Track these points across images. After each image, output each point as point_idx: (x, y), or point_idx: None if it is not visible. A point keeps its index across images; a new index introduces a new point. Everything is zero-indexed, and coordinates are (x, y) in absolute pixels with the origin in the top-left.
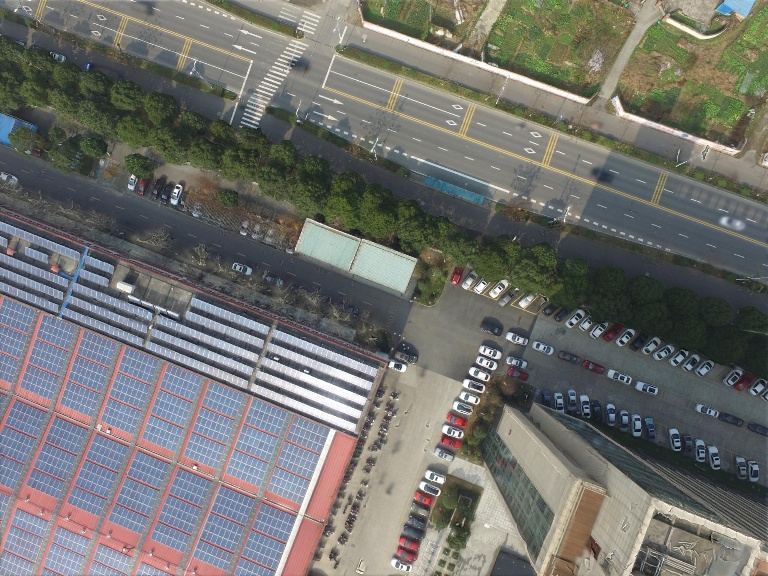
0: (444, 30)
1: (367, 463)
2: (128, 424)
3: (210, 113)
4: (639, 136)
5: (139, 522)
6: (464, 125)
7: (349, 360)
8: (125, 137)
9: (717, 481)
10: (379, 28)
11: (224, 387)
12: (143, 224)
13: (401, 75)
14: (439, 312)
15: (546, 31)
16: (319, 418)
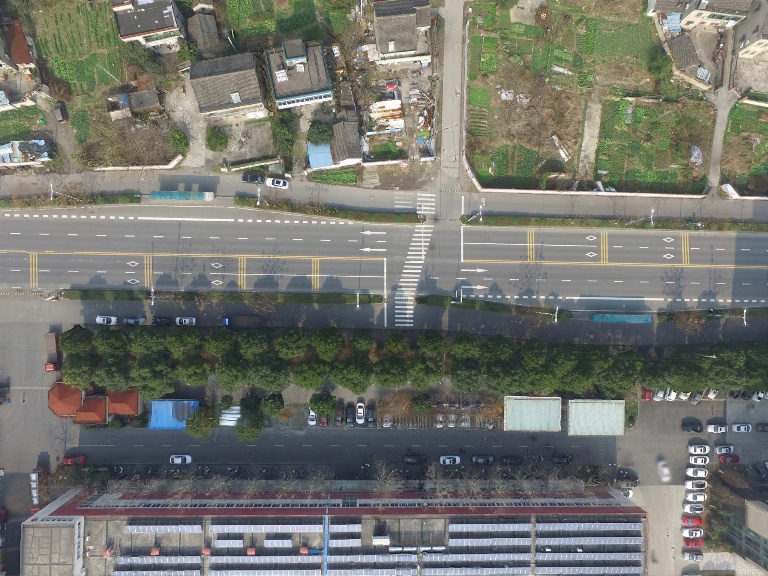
0: (559, 174)
1: None
2: None
3: (362, 322)
4: (755, 211)
5: None
6: (603, 253)
7: (615, 524)
8: (303, 384)
9: None
10: (497, 190)
11: None
12: (336, 453)
13: (531, 226)
14: (641, 430)
15: (645, 143)
16: None
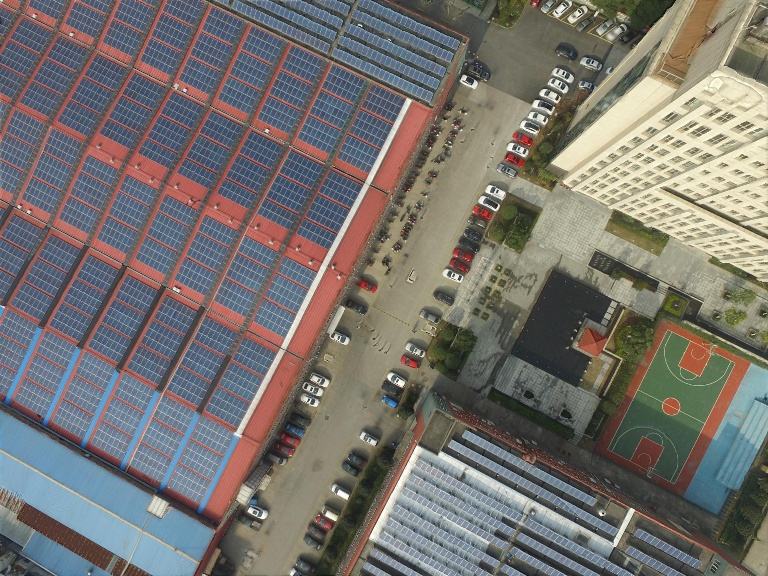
0: None
1: (429, 173)
2: (205, 84)
3: None
4: None
5: (207, 177)
6: None
7: (432, 31)
8: None
9: None
10: None
11: (305, 51)
12: None
13: None
14: (515, 34)
15: None
16: (396, 87)
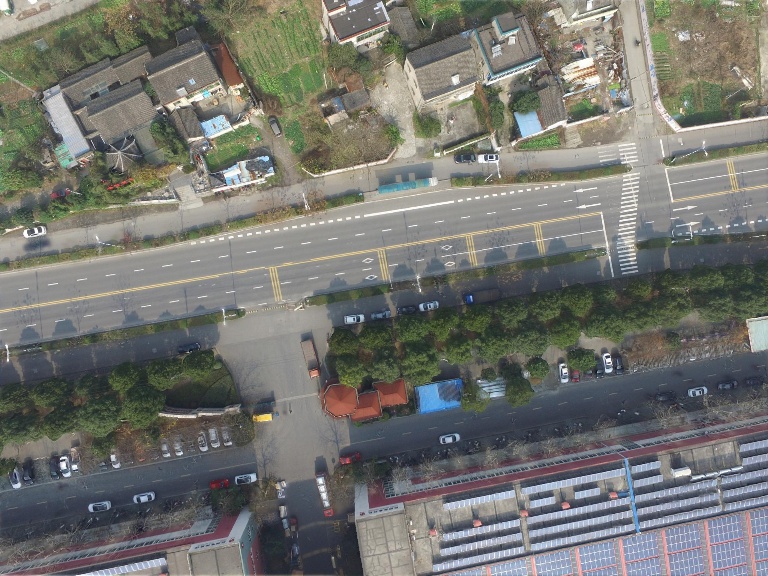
0: None
1: None
2: None
3: (591, 277)
4: None
5: None
6: None
7: None
8: (562, 343)
9: None
10: (695, 127)
11: None
12: (591, 405)
13: (730, 156)
14: None
15: None
16: None
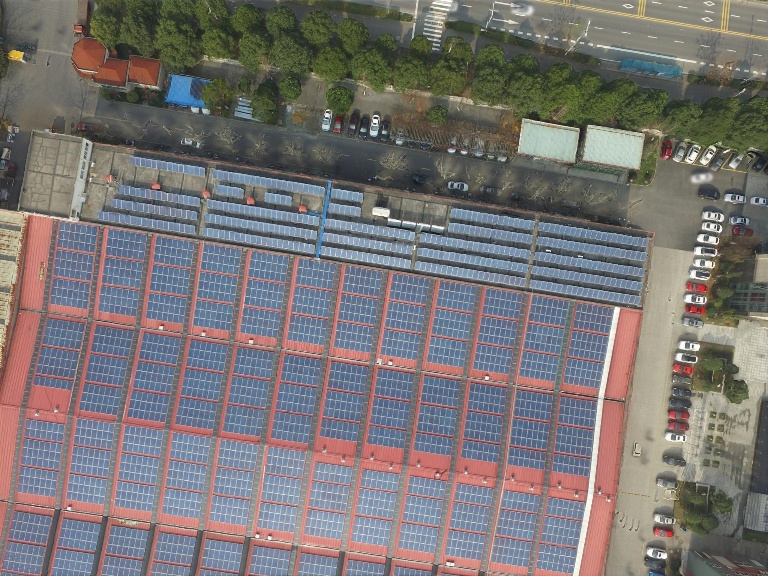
0: None
1: None
2: (409, 351)
3: None
4: None
5: (445, 444)
6: (641, 6)
7: (619, 236)
8: (323, 71)
9: None
10: None
11: (501, 291)
12: (345, 163)
13: None
14: (656, 189)
15: None
16: (602, 299)
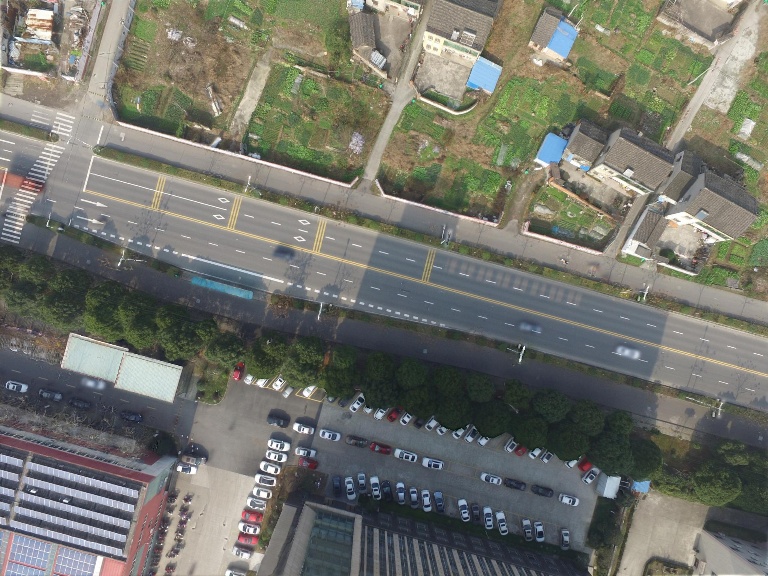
0: (199, 125)
1: (165, 570)
2: None
3: None
4: (405, 215)
5: None
6: (232, 218)
7: (108, 485)
8: None
9: (507, 545)
10: (134, 127)
11: None
12: None
13: (163, 172)
14: (225, 409)
15: (305, 117)
16: (85, 546)
